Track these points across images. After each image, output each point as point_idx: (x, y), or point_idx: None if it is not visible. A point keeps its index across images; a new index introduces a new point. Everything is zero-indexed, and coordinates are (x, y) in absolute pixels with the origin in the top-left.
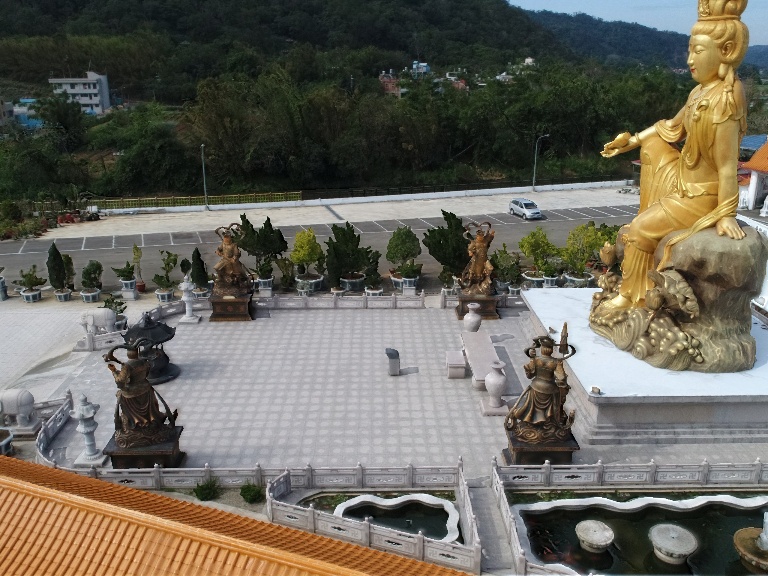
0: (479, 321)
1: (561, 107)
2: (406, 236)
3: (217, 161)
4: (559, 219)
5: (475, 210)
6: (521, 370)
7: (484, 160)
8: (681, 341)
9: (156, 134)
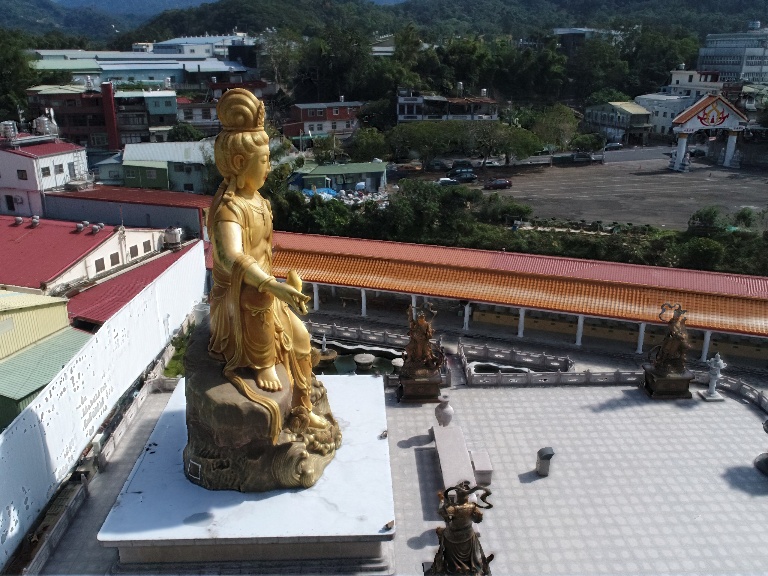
0: None
1: None
2: None
3: None
4: None
5: None
6: (413, 479)
7: None
8: None
9: None
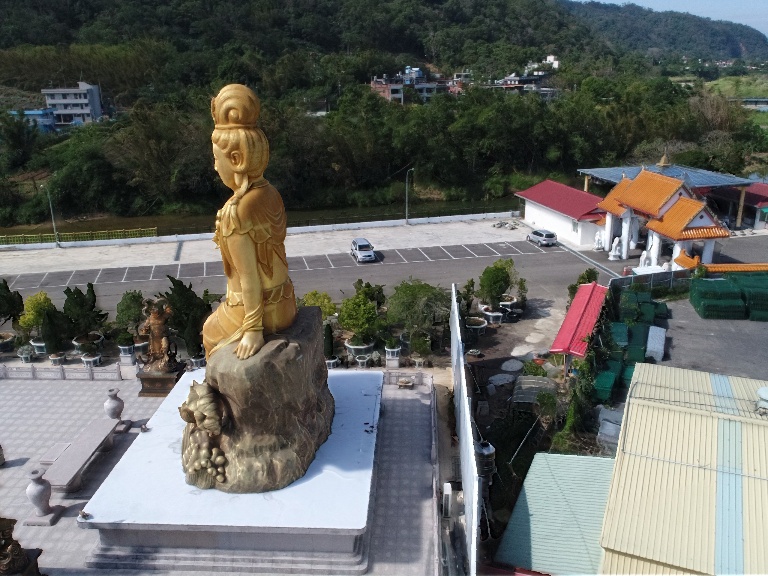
0: (116, 408)
1: (504, 123)
2: (131, 301)
3: (142, 182)
4: (393, 262)
5: (321, 249)
6: None
7: (424, 178)
8: (201, 459)
9: (85, 156)
